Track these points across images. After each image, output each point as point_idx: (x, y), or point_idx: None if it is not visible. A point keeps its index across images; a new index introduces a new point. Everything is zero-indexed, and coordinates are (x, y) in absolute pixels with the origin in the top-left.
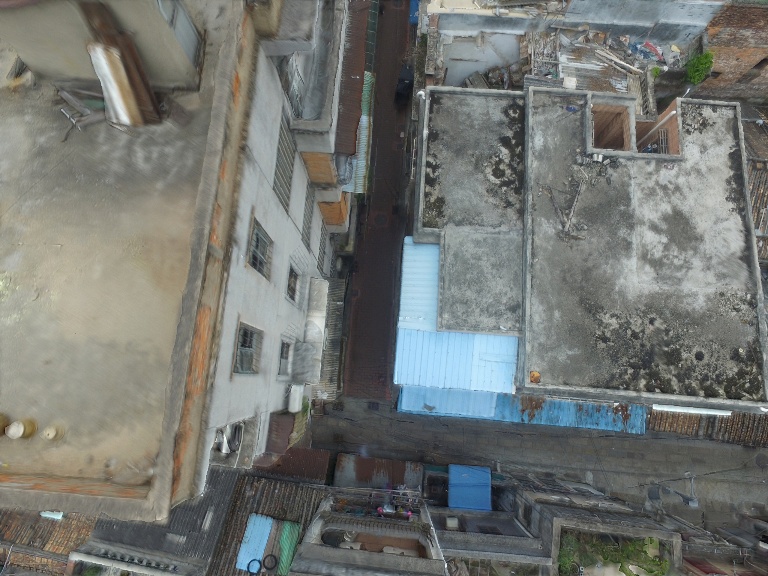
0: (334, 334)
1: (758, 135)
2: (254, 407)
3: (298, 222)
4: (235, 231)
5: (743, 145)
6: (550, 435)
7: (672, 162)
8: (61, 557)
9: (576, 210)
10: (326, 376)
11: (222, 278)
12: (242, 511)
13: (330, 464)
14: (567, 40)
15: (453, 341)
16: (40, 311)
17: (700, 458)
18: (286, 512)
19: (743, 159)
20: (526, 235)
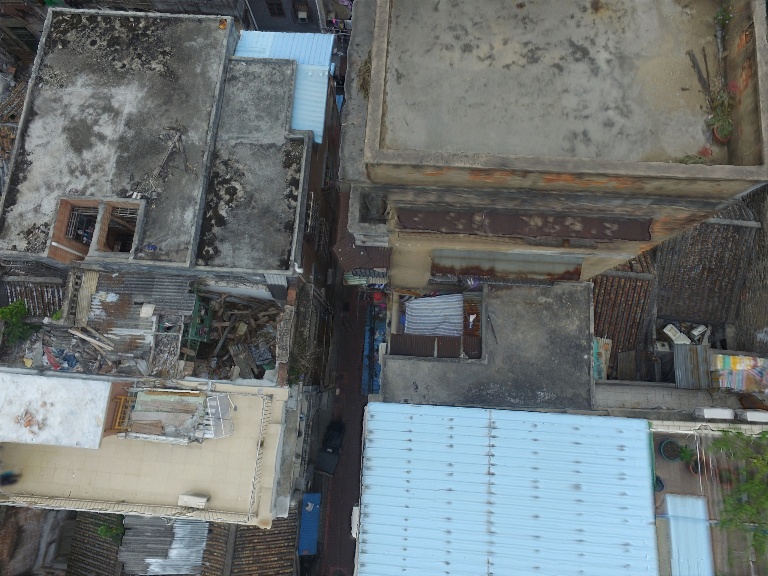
0: None
1: None
2: None
3: None
4: None
5: None
6: None
7: None
8: None
9: (166, 152)
10: None
11: None
12: None
13: None
14: (140, 367)
15: None
16: None
17: None
18: None
19: (5, 196)
20: None
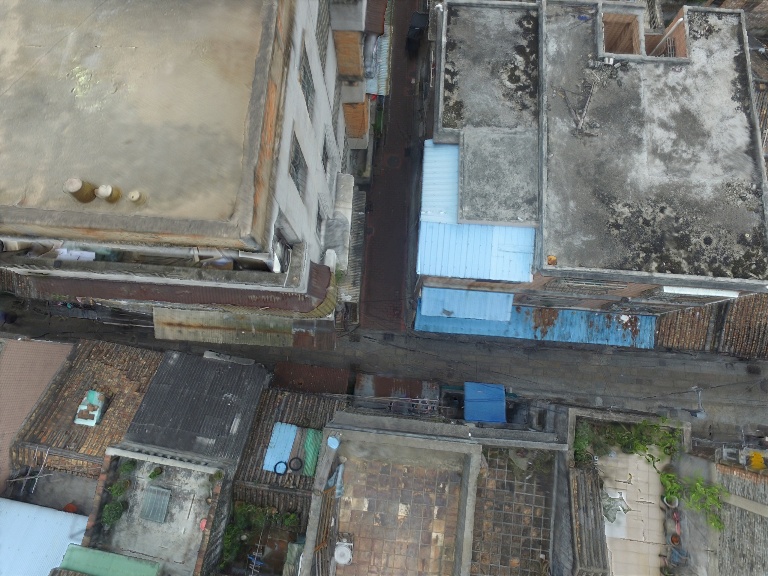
0: (356, 242)
1: (761, 61)
2: (301, 232)
3: (330, 100)
4: (293, 34)
5: (747, 48)
6: (561, 363)
7: (680, 65)
8: (96, 459)
9: (589, 110)
10: (349, 280)
11: (283, 70)
12: (267, 420)
13: (349, 385)
14: None
15: (473, 233)
16: (119, 102)
17: (706, 384)
18: (309, 421)
19: (747, 61)
20: (541, 133)
